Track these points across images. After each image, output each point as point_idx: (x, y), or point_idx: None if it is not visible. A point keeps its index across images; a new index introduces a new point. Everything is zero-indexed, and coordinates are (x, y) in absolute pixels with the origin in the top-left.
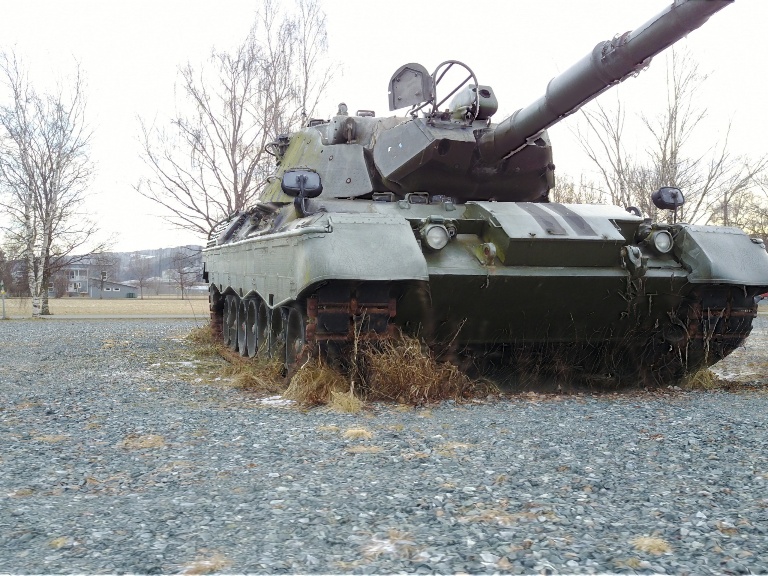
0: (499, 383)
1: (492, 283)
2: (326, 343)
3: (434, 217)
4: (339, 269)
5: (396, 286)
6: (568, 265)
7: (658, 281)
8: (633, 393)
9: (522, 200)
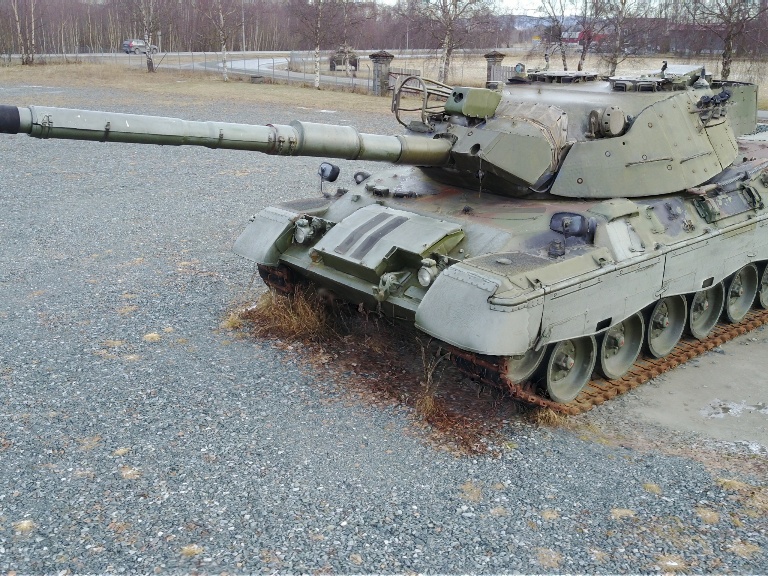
0: None
1: None
2: None
3: (298, 221)
4: (235, 246)
5: None
6: None
7: None
8: (372, 387)
9: (509, 194)
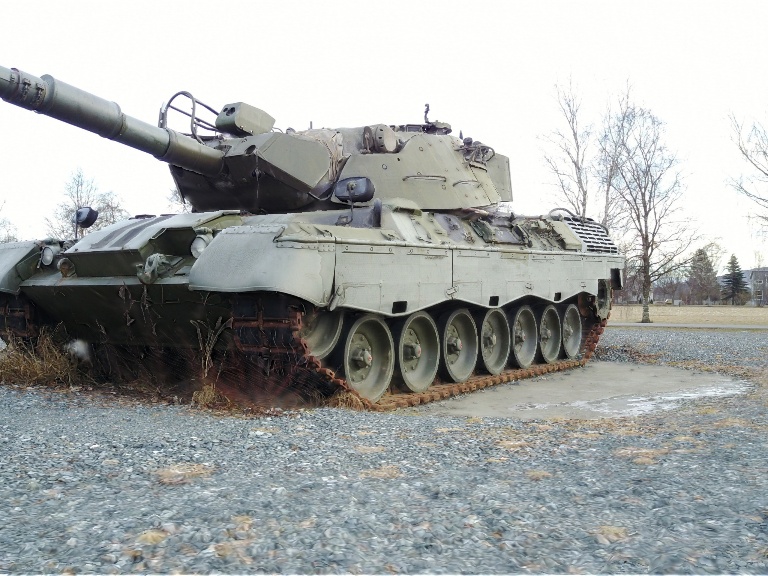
0: (246, 388)
1: (67, 292)
2: (3, 337)
3: None
4: None
5: (7, 295)
6: (117, 275)
7: (175, 288)
8: None
9: (288, 207)
